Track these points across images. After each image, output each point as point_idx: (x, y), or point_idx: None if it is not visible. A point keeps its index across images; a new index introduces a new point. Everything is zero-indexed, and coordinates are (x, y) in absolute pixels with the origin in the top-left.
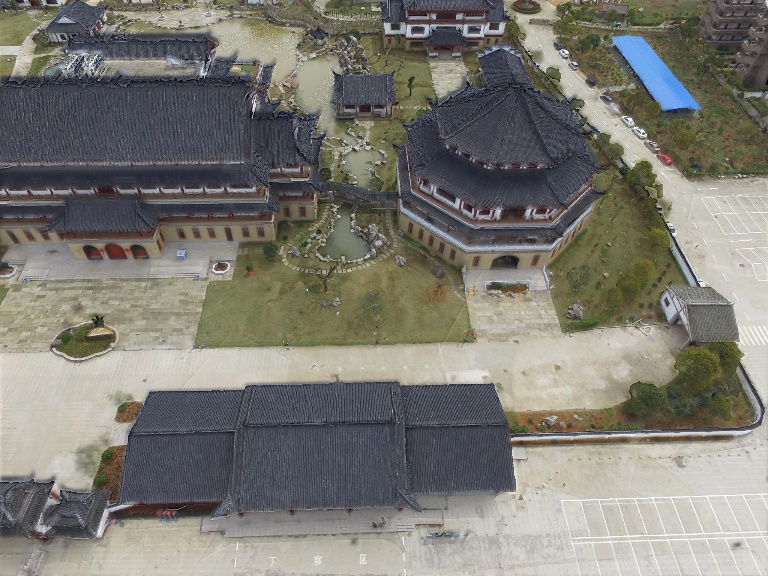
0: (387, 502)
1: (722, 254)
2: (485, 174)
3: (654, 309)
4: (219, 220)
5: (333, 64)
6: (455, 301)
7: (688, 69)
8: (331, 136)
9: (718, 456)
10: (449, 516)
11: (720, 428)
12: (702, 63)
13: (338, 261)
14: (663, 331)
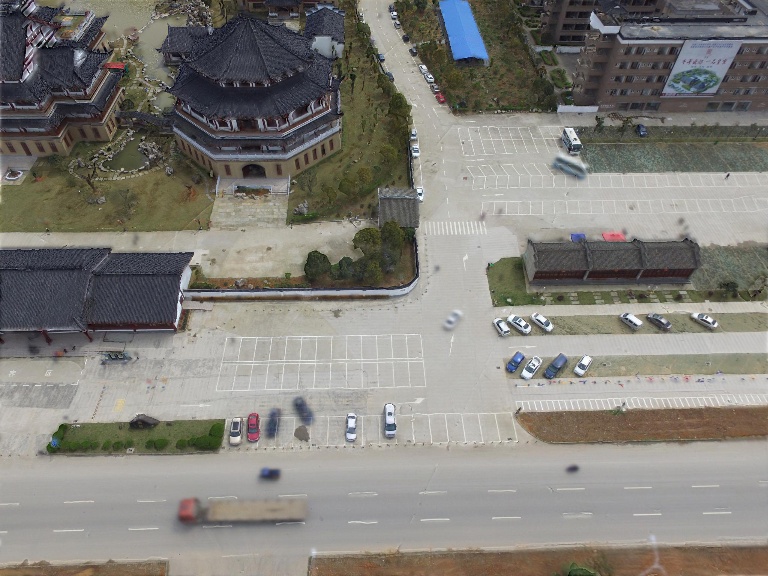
0: (63, 325)
1: (453, 170)
2: (222, 91)
3: (372, 209)
4: (13, 135)
5: (181, 22)
6: (204, 201)
7: (500, 28)
8: (154, 79)
9: (371, 310)
10: (130, 346)
11: (373, 287)
12: (503, 21)
13: (117, 171)
14: (372, 224)
